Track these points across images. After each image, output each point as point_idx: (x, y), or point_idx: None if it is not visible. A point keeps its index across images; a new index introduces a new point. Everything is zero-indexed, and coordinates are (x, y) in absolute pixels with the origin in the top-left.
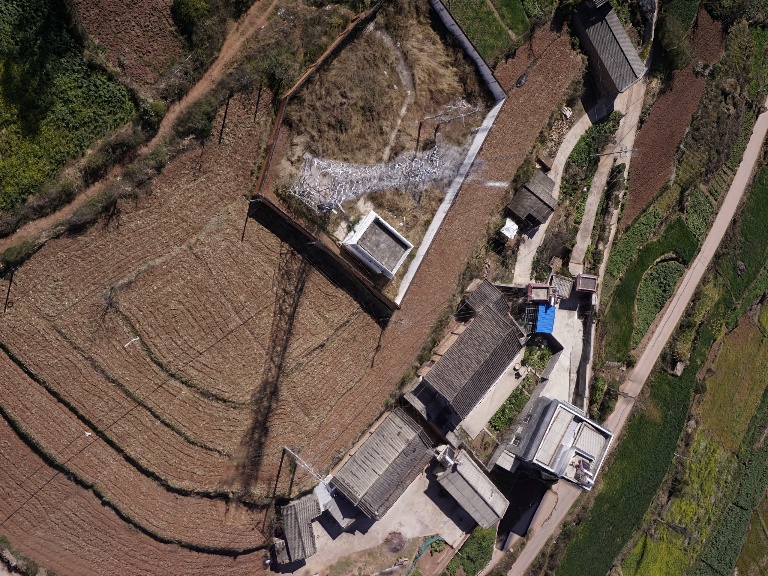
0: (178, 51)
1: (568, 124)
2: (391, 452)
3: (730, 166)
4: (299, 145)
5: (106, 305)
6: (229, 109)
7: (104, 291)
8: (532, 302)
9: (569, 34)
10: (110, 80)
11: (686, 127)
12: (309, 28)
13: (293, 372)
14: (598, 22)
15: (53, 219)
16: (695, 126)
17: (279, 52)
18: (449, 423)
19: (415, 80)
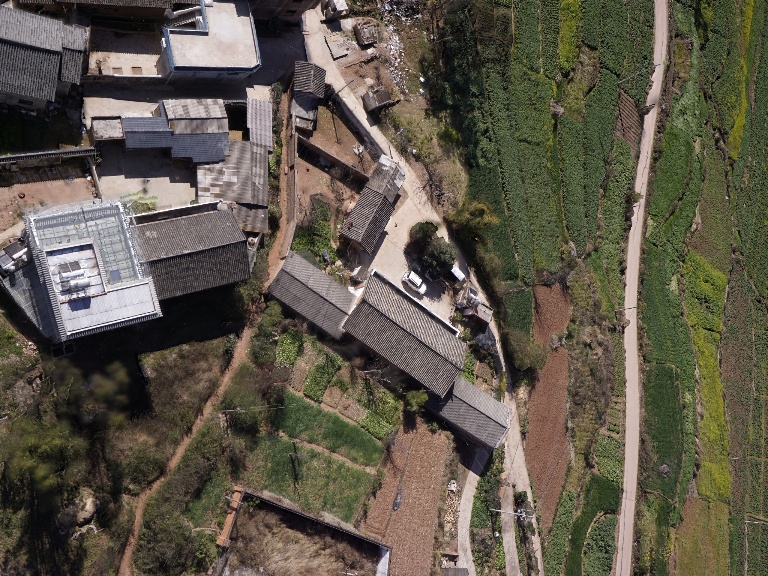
0: None
1: (457, 496)
2: None
3: (618, 394)
4: None
5: None
6: None
7: None
8: None
9: (424, 422)
10: None
11: (566, 403)
12: None
13: None
14: (448, 400)
15: None
16: (573, 393)
17: None
18: None
19: None
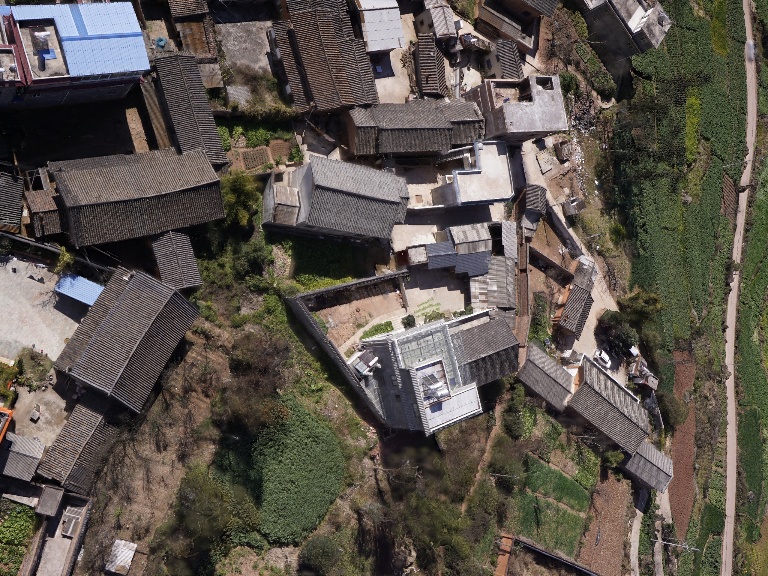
0: None
1: (629, 530)
2: None
3: (722, 435)
4: None
5: None
6: None
7: None
8: None
9: (613, 474)
10: None
11: (694, 448)
12: None
13: None
14: None
15: None
16: (697, 438)
17: None
18: None
19: None
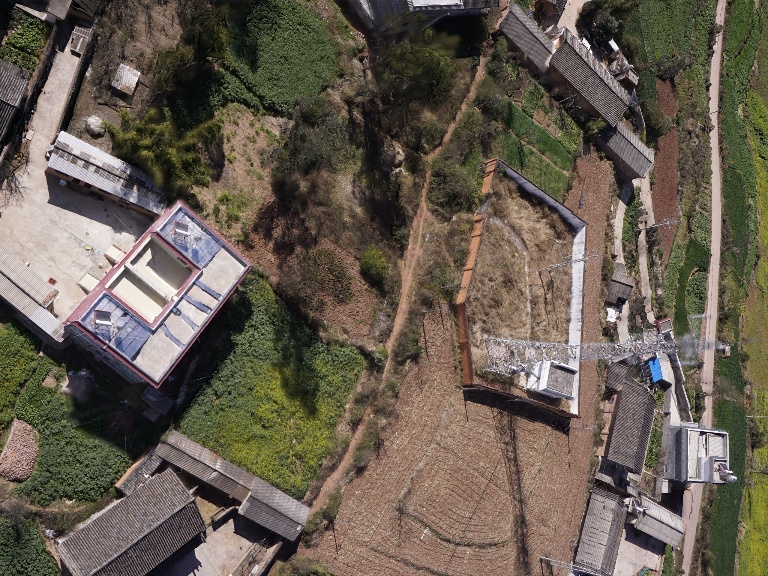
0: (375, 301)
1: None
2: (605, 524)
3: (706, 181)
4: (477, 331)
5: (399, 515)
6: (425, 328)
7: (394, 505)
8: (645, 362)
9: (595, 151)
10: (342, 346)
11: (677, 172)
12: (450, 241)
13: (529, 500)
14: (613, 134)
15: (341, 468)
16: (680, 167)
17: (443, 271)
18: (625, 480)
19: (526, 243)
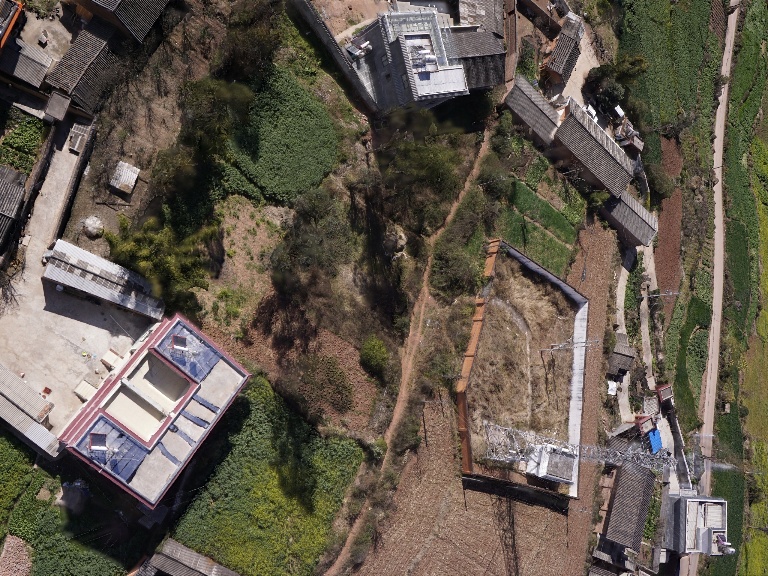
0: (374, 391)
1: (616, 283)
2: None
3: (709, 236)
4: (477, 418)
5: None
6: (425, 417)
7: None
8: (645, 434)
9: (599, 220)
10: (340, 439)
11: (680, 232)
12: (451, 325)
13: None
14: (617, 204)
15: (338, 564)
16: (684, 226)
17: (444, 358)
18: (623, 555)
19: (528, 322)
